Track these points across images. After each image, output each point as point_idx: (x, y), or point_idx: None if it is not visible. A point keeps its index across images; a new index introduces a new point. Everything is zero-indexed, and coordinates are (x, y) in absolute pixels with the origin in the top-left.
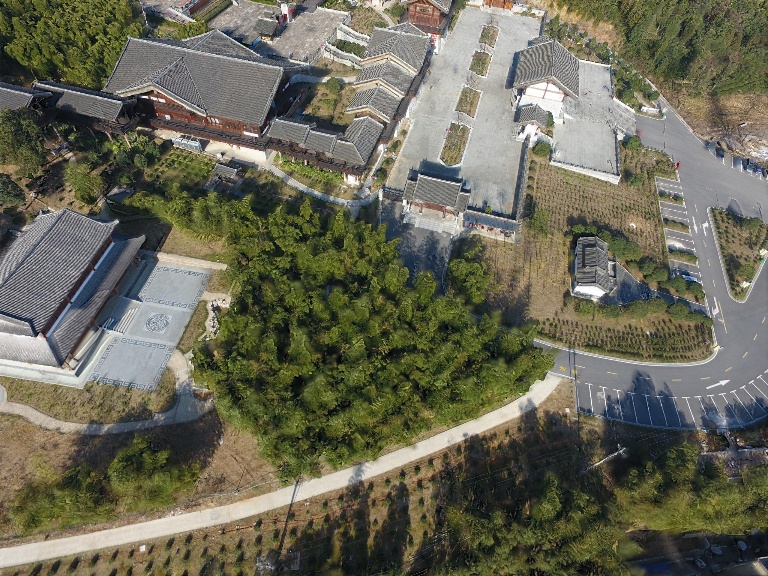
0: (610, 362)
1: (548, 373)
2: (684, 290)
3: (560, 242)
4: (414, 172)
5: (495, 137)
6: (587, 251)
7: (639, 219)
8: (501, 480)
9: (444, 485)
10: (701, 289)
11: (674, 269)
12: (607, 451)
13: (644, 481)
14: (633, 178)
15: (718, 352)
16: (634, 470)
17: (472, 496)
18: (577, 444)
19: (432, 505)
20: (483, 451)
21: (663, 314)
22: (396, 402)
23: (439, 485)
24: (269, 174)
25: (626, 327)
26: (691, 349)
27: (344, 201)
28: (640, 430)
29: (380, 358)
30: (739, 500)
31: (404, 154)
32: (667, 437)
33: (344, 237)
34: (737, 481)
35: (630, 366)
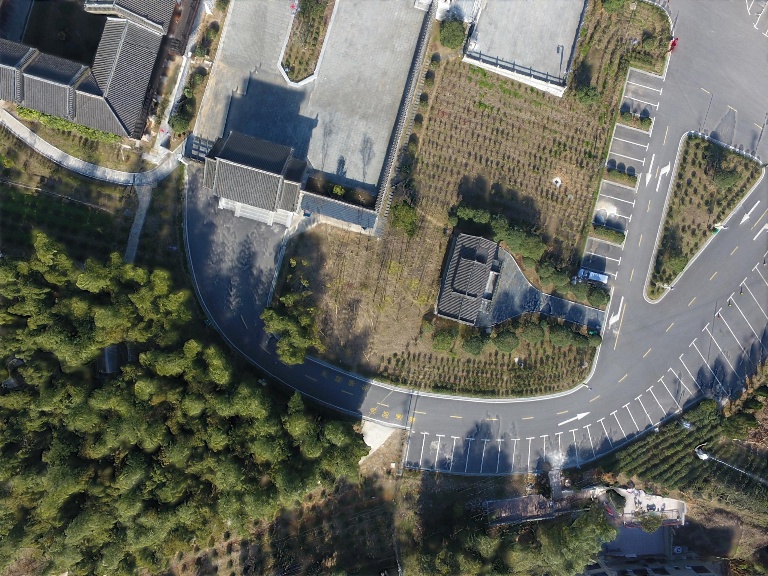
0: (457, 403)
1: (380, 424)
2: (584, 296)
3: (440, 227)
4: (239, 98)
5: (381, 1)
6: (462, 263)
7: (571, 167)
8: (310, 539)
9: (253, 547)
10: (603, 301)
11: (588, 254)
12: (424, 505)
13: (433, 567)
14: (583, 94)
15: (592, 377)
16: (428, 555)
17: (280, 554)
18: (395, 499)
19: (240, 565)
20: (296, 512)
21: (545, 330)
22: (178, 520)
23: (248, 548)
24: (2, 132)
25: (491, 355)
26: (561, 377)
27: (128, 176)
28: (465, 481)
29: (158, 473)
30: (529, 562)
31: (224, 55)
32: (492, 485)
33: (109, 288)
34: (547, 522)
35: (479, 406)
